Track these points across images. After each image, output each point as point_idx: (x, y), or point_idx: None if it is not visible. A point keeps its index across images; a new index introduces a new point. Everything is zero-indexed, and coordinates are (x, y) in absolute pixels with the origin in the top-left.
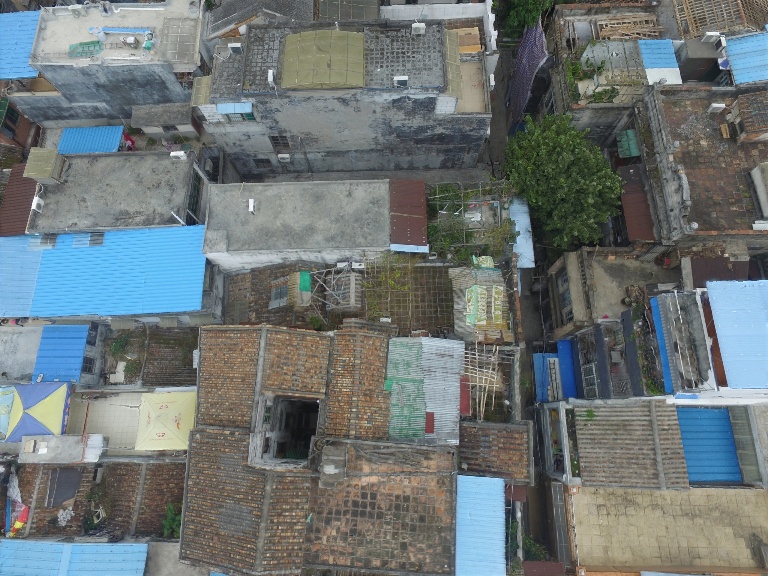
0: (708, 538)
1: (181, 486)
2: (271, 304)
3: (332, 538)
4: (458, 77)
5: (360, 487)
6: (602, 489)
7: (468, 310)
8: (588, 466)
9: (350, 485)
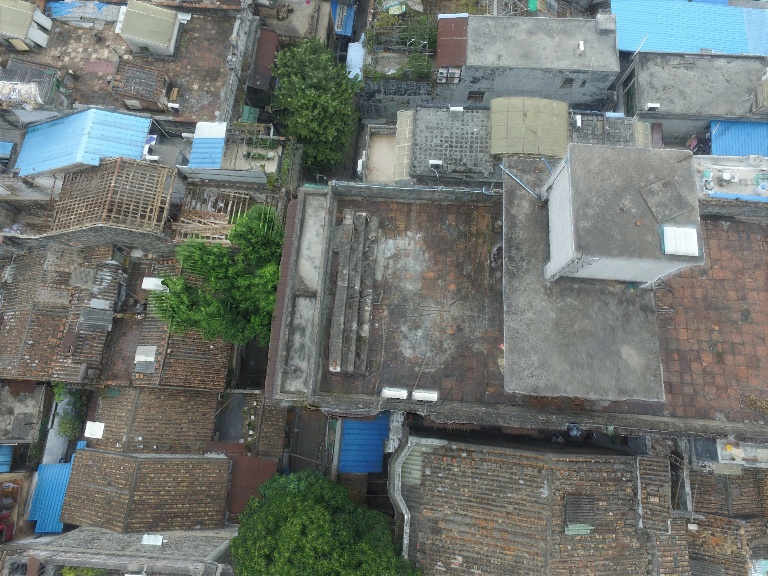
0: None
1: None
2: (557, 5)
3: None
4: (399, 133)
5: None
6: None
7: None
8: None
9: None
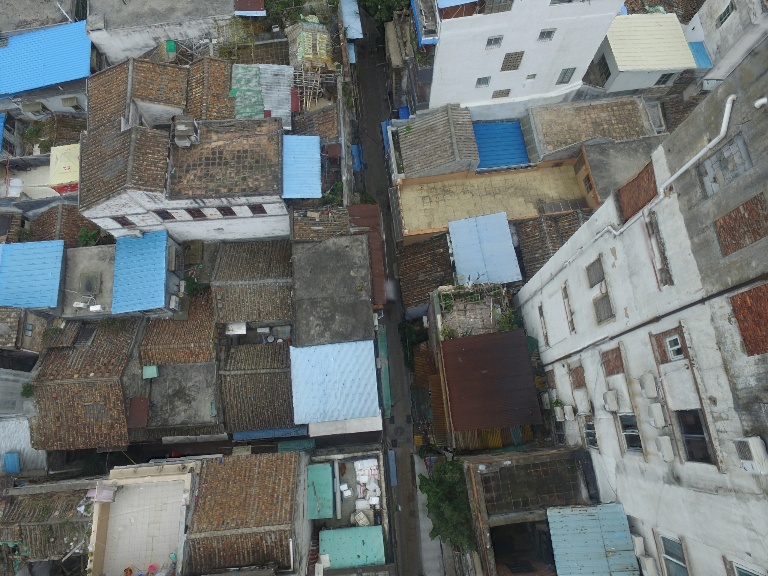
0: (506, 206)
1: (94, 223)
2: None
3: (191, 180)
4: None
5: (210, 149)
6: (426, 186)
7: (299, 51)
8: (408, 163)
9: (203, 148)
